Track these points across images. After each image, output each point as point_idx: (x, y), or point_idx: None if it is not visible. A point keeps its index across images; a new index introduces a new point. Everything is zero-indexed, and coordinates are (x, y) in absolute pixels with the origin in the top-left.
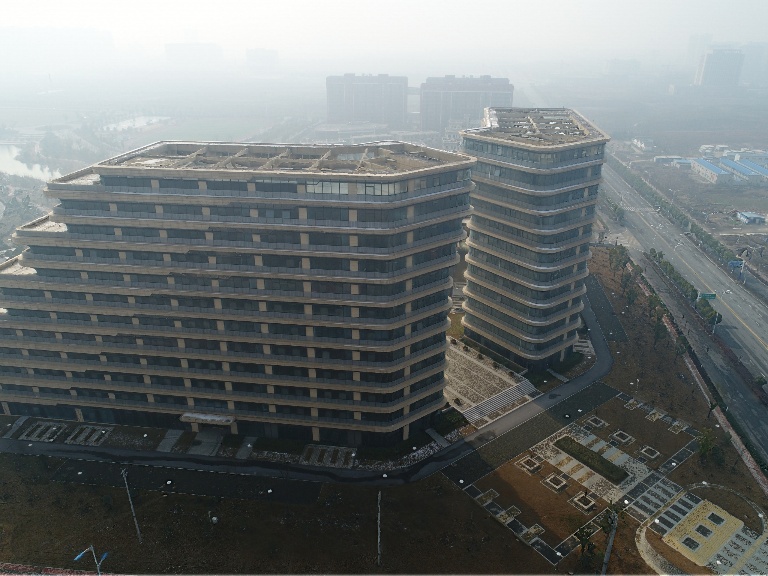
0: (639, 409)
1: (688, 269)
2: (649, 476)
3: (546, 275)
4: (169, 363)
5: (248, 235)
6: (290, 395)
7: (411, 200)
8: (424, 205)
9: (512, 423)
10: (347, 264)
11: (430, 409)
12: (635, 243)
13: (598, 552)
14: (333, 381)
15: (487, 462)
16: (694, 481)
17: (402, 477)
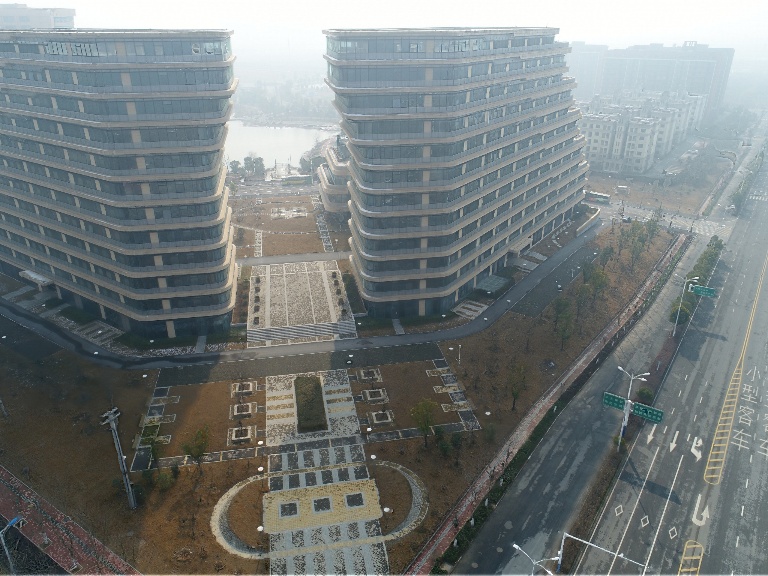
0: (438, 378)
1: (758, 269)
2: (346, 437)
3: (377, 199)
4: (15, 221)
5: (26, 98)
6: (80, 267)
7: (117, 64)
8: (145, 75)
9: (285, 352)
10: (83, 132)
11: (198, 312)
12: (723, 233)
13: (182, 477)
14: (100, 257)
15: (210, 375)
16: (389, 458)
17: (125, 363)
